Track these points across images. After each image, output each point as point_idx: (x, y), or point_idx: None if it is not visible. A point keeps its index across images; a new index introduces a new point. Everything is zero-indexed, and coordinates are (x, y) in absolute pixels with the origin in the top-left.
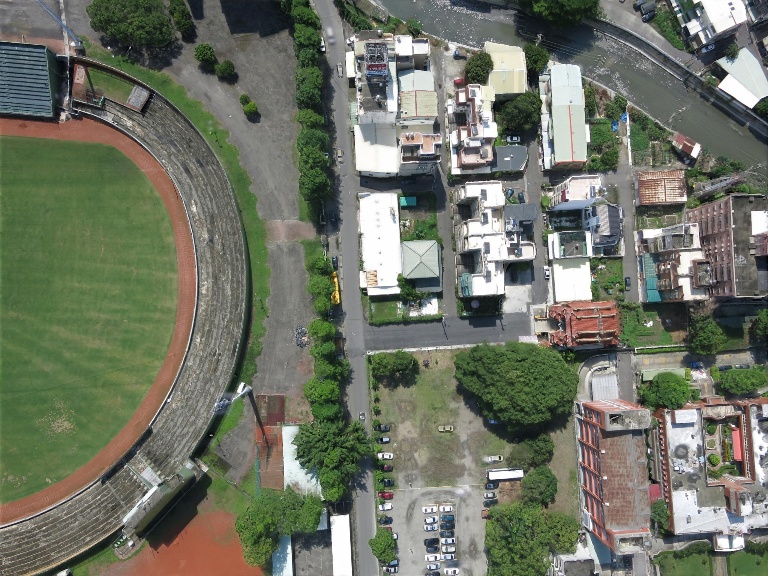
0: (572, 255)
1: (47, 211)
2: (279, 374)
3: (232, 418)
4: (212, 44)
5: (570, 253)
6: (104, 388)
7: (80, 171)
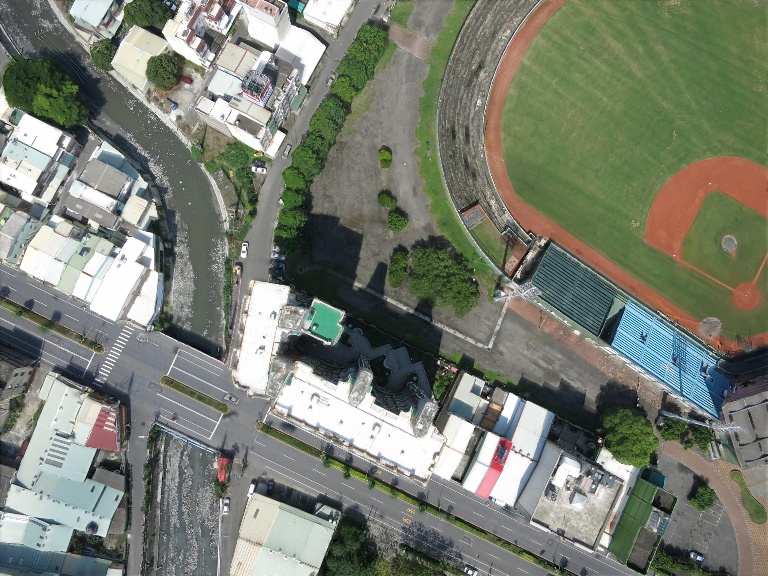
0: None
1: (597, 171)
2: None
3: None
4: (385, 235)
5: None
6: (626, 7)
7: (553, 188)
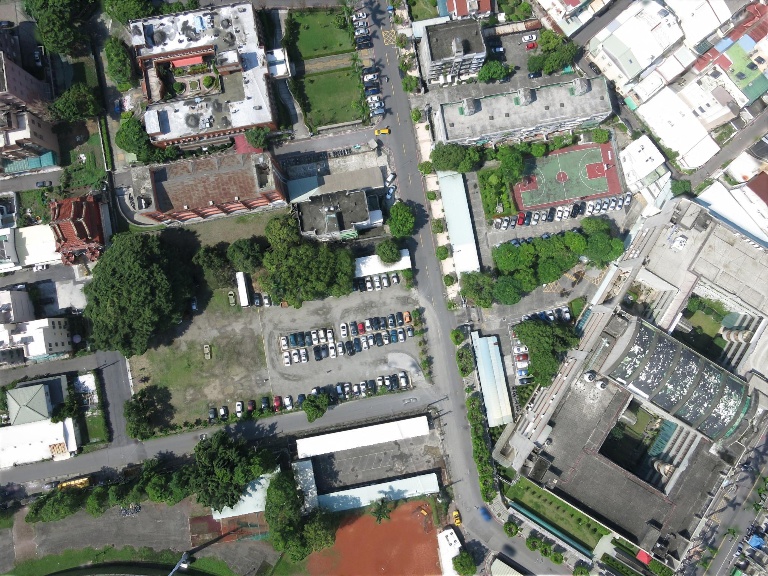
0: (4, 252)
1: None
2: (169, 526)
3: (217, 567)
4: None
5: (2, 255)
6: None
7: None
